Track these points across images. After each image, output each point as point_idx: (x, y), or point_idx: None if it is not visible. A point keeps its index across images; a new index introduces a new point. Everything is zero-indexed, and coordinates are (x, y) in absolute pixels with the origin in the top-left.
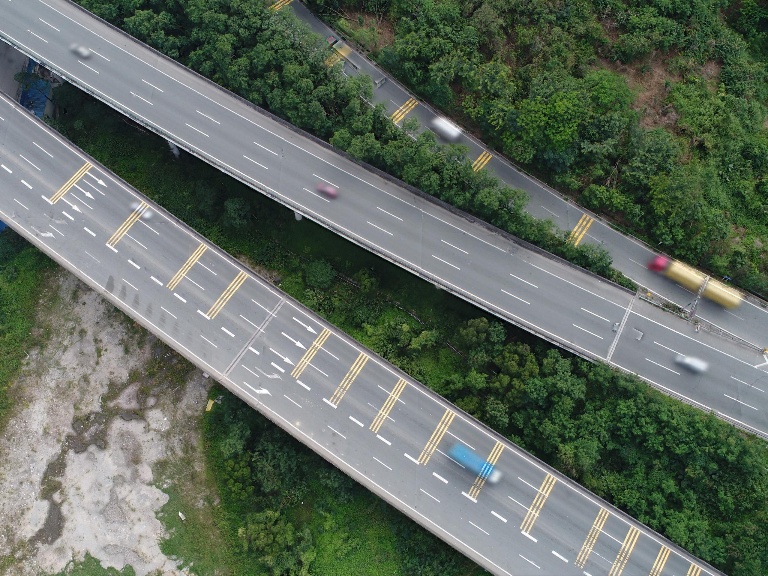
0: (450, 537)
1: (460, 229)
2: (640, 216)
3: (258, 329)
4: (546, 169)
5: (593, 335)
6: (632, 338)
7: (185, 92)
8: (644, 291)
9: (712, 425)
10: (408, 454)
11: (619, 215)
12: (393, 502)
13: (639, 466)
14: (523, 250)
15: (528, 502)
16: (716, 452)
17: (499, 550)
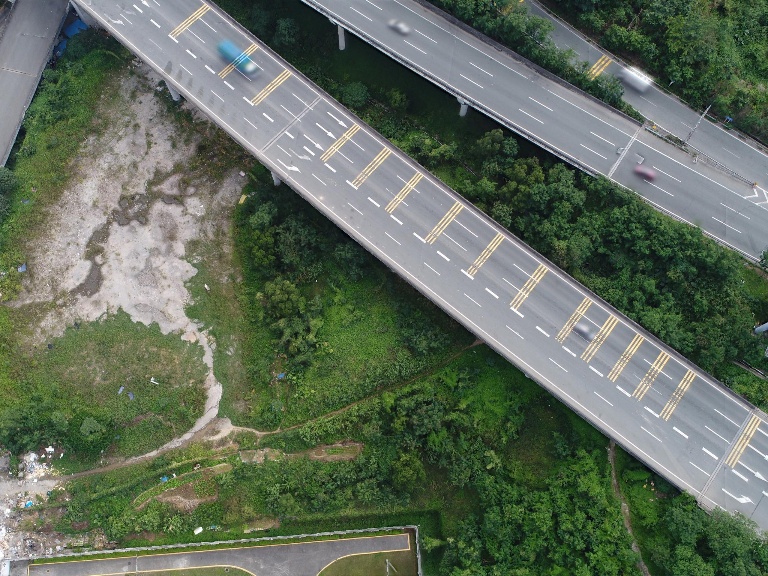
0: (446, 304)
1: (488, 55)
2: (655, 54)
3: (295, 118)
4: (574, 11)
5: (598, 155)
6: (634, 161)
7: None
8: (650, 123)
9: (696, 232)
10: (417, 233)
11: (636, 59)
12: (398, 270)
13: (625, 269)
14: (543, 78)
15: (520, 285)
16: (697, 256)
17: (488, 320)
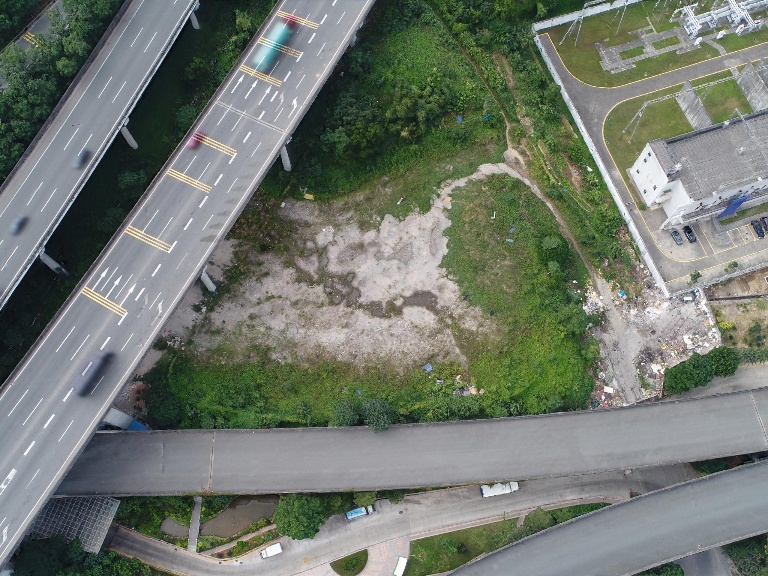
0: None
1: None
2: None
3: (243, 116)
4: None
5: None
6: None
7: (5, 220)
8: None
9: None
10: (333, 3)
11: None
12: (368, 7)
13: None
14: None
15: None
16: None
17: None
